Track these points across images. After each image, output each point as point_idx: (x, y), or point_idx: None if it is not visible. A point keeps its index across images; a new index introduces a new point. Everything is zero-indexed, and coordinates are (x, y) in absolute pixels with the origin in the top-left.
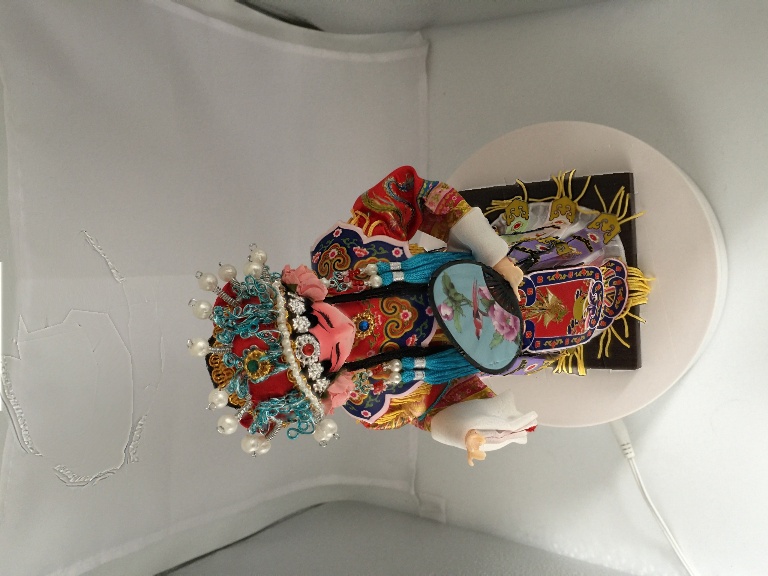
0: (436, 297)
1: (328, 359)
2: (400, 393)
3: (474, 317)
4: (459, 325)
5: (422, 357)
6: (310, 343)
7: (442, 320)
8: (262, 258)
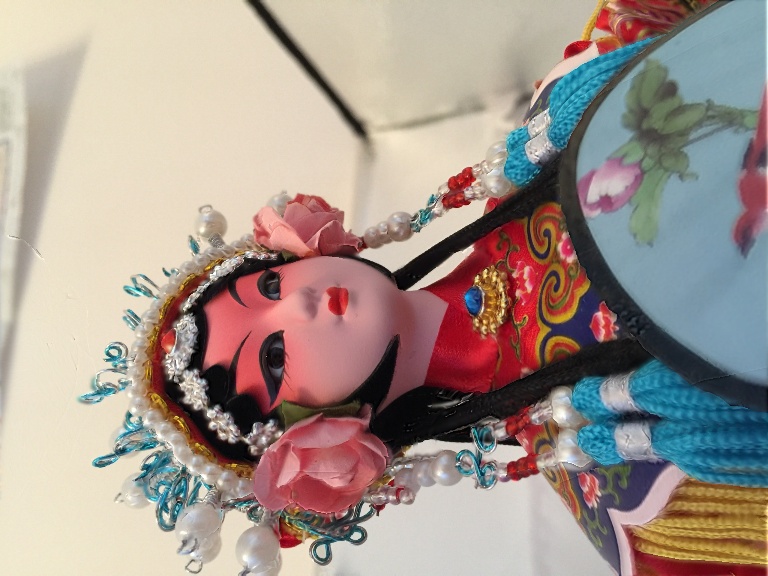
0: (585, 152)
1: (225, 364)
2: (631, 508)
3: (747, 167)
4: (651, 218)
5: (627, 373)
6: None
7: (582, 219)
8: None
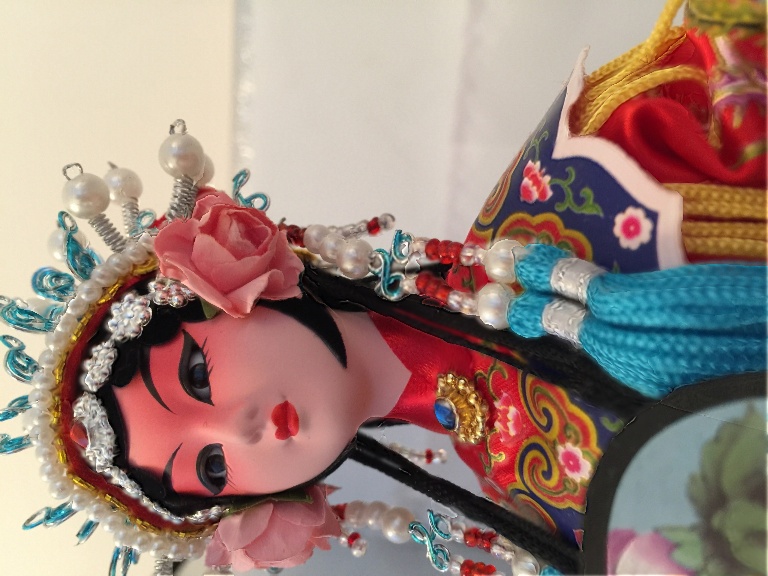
0: (629, 491)
1: (156, 471)
2: None
3: None
4: None
5: None
6: (89, 421)
7: None
8: (188, 162)
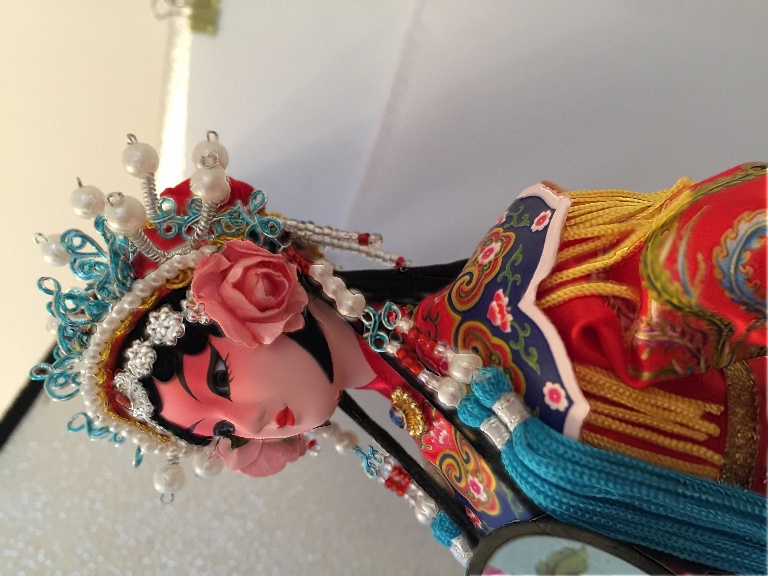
0: (504, 552)
1: (182, 427)
2: None
3: None
4: None
5: (470, 550)
6: (132, 394)
7: None
8: (215, 191)
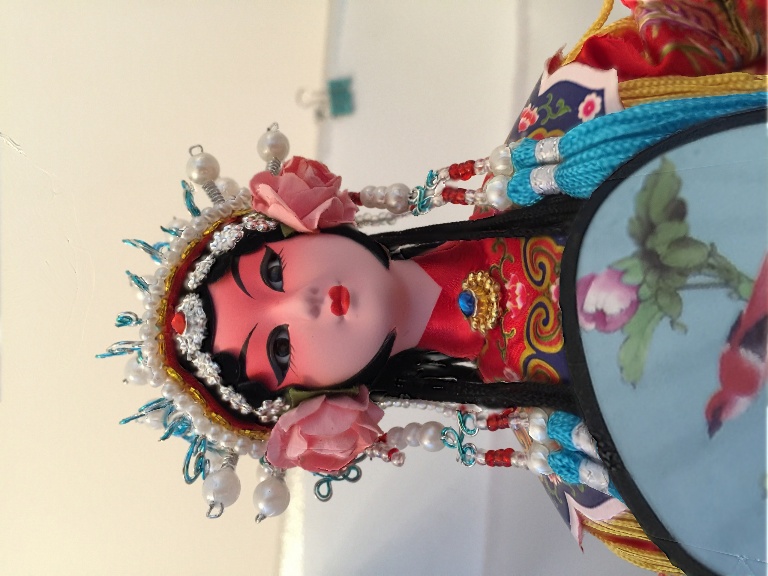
0: (589, 246)
1: (235, 351)
2: (585, 505)
3: (731, 342)
4: (638, 357)
5: None
6: (188, 311)
7: (577, 326)
8: (278, 149)
